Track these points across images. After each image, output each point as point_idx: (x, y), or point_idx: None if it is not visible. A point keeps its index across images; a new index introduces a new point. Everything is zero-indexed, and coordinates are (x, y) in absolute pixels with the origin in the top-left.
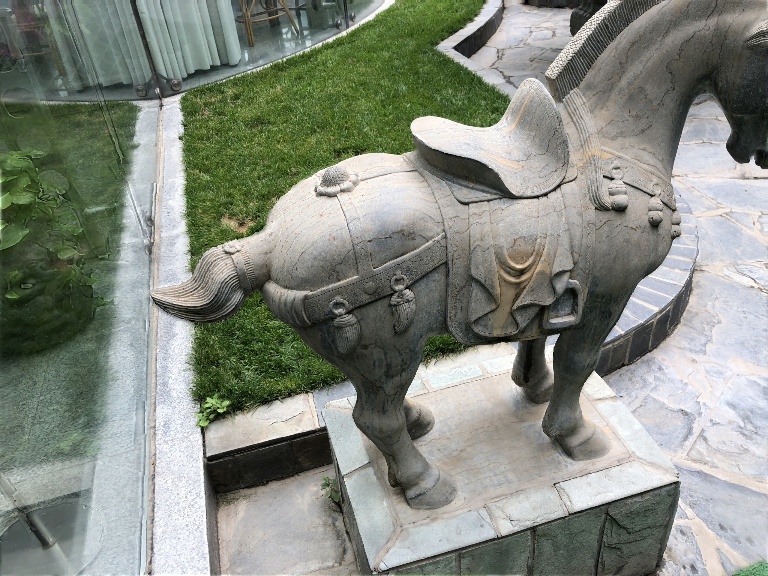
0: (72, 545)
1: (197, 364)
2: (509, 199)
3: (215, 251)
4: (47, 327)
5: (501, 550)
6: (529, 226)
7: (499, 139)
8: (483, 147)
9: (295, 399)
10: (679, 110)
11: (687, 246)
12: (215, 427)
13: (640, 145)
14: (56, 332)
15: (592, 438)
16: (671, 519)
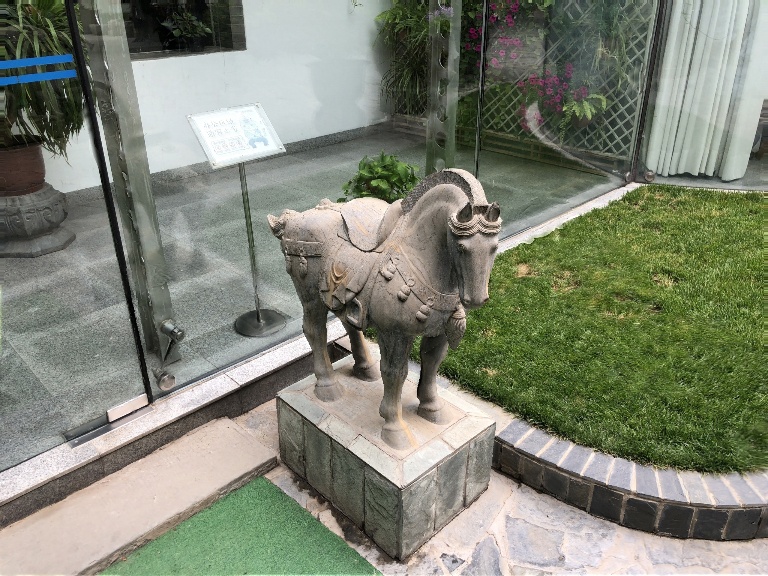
0: (265, 328)
1: None
2: (352, 244)
3: (286, 210)
4: None
5: (319, 438)
6: (348, 260)
7: (375, 219)
8: (359, 217)
9: None
10: (444, 250)
11: (760, 495)
12: None
13: (418, 256)
14: None
15: (392, 432)
16: (401, 521)
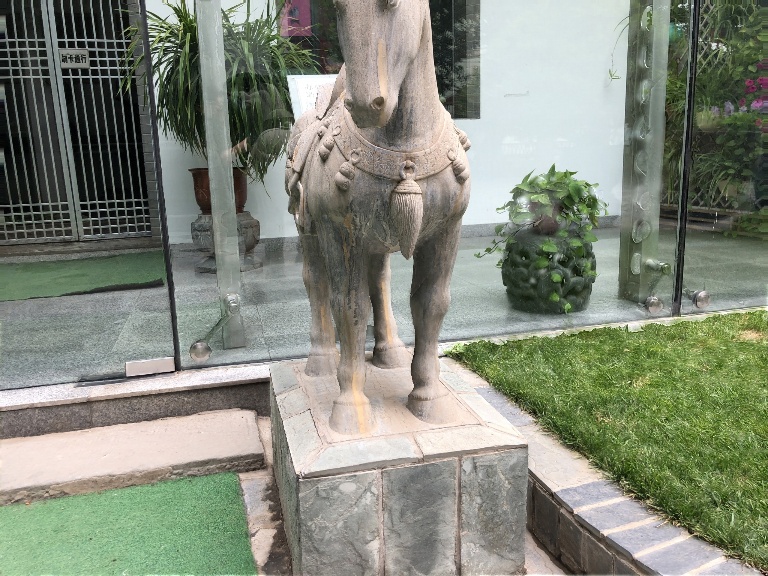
0: None
1: (507, 341)
2: None
3: None
4: (521, 293)
5: None
6: None
7: None
8: None
9: (481, 381)
10: None
11: None
12: (447, 359)
13: None
14: (525, 300)
15: (338, 405)
16: None
